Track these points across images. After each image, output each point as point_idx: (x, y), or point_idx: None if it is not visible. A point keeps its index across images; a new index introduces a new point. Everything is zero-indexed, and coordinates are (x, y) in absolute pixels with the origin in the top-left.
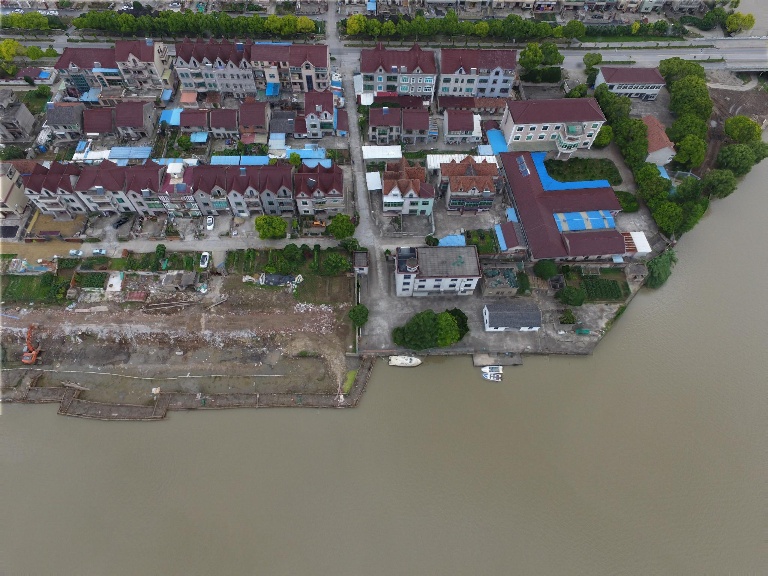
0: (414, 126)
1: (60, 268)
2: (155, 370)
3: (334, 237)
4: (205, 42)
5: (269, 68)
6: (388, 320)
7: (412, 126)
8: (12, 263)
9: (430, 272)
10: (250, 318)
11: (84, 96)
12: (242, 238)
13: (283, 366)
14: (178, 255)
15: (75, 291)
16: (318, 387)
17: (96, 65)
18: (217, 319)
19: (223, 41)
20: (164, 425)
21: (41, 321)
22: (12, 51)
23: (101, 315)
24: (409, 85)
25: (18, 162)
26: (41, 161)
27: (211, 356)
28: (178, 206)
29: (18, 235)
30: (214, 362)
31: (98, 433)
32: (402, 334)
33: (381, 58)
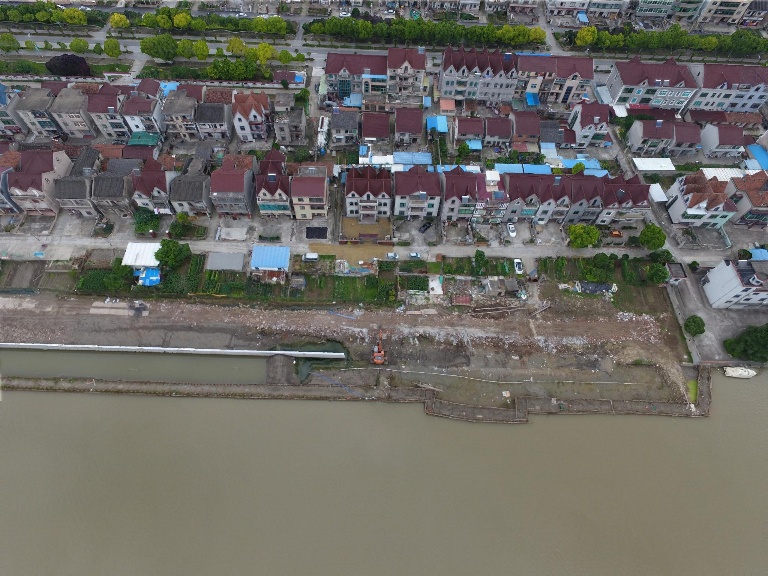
0: (686, 139)
1: (380, 270)
2: (498, 373)
3: (635, 247)
4: (436, 50)
5: (535, 78)
6: (713, 331)
7: (684, 139)
8: (338, 264)
9: (766, 286)
10: (577, 325)
11: (347, 101)
12: (546, 246)
13: (620, 374)
14: (489, 261)
15: (405, 293)
16: (661, 395)
17: (366, 71)
18: (545, 325)
19: (487, 51)
20: (530, 428)
21: (378, 322)
22: (269, 55)
23: (432, 318)
24: (664, 98)
25: (314, 165)
26: (333, 164)
27: (547, 361)
28: (485, 213)
29: (329, 236)
30: (552, 367)
31: (469, 434)
32: (744, 346)
33: (645, 71)
